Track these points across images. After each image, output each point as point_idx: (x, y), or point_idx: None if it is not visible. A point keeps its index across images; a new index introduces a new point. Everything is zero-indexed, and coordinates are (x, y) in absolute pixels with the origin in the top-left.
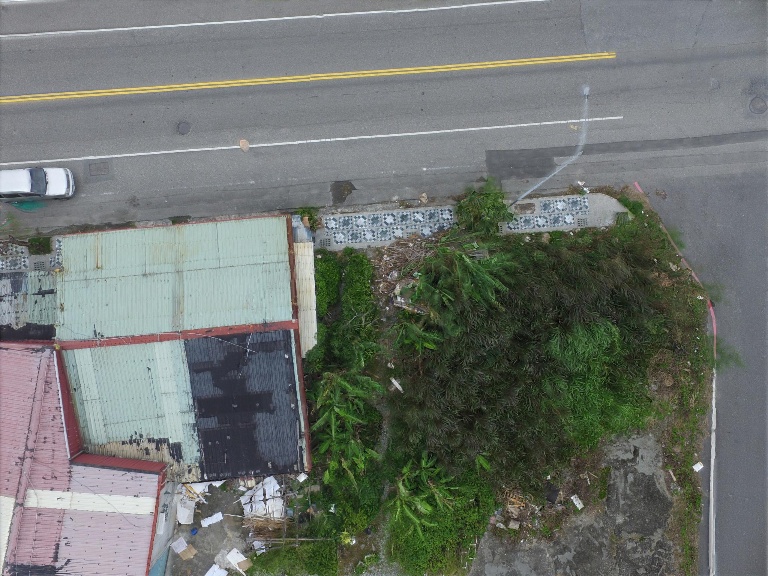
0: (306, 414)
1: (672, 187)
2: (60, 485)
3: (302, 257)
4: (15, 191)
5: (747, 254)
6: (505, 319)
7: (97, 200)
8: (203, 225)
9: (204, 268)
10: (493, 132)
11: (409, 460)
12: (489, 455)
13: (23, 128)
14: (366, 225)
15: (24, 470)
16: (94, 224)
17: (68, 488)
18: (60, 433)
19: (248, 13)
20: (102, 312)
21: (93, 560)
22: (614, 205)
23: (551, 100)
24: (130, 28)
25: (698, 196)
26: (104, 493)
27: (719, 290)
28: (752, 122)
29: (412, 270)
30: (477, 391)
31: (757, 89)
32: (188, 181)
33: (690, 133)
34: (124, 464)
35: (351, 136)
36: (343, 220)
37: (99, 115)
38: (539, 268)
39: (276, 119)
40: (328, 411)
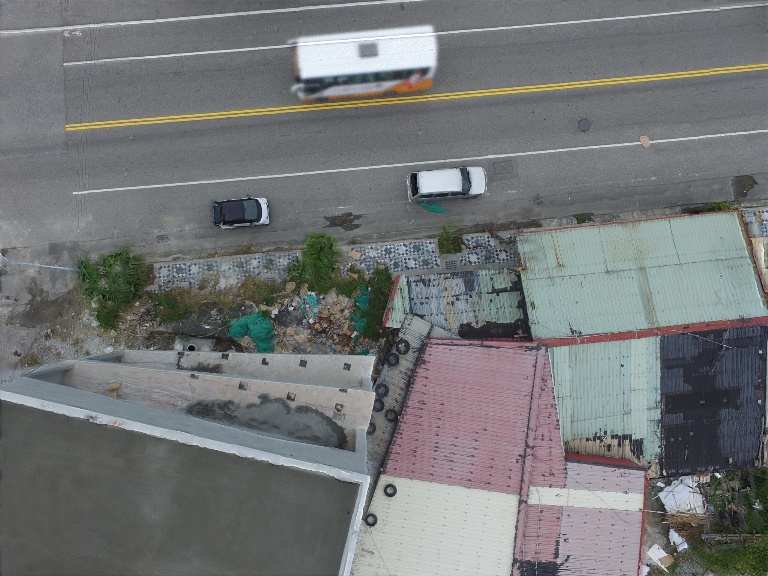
0: None
1: None
2: (558, 482)
3: None
4: (450, 190)
5: None
6: None
7: (501, 198)
8: (656, 221)
9: (667, 264)
10: None
11: None
12: None
13: (428, 128)
14: None
15: (527, 467)
16: (499, 222)
17: (564, 485)
18: (556, 430)
19: (643, 8)
20: (573, 310)
21: (590, 556)
22: None
23: None
24: (527, 26)
25: None
26: (597, 490)
27: None
28: None
29: None
30: None
31: None
32: (591, 178)
33: None
34: (604, 461)
35: (751, 130)
36: None
37: (501, 113)
38: None
39: (676, 114)
40: None
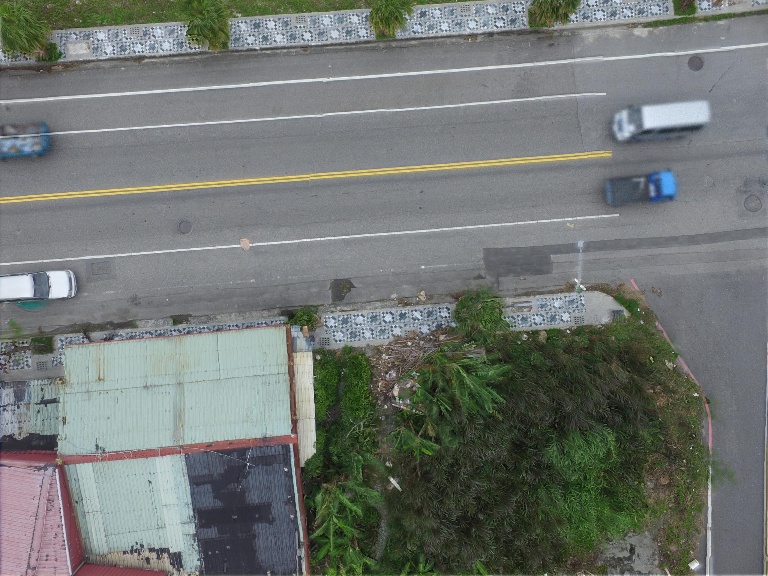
0: (305, 524)
1: (668, 284)
2: None
3: (301, 366)
4: (18, 297)
5: (742, 351)
6: (502, 429)
7: (99, 299)
8: (204, 335)
9: (205, 380)
10: (491, 230)
11: (407, 563)
12: (486, 561)
13: (26, 228)
14: (365, 323)
15: None
16: (96, 323)
17: None
18: (62, 550)
19: (249, 112)
20: (104, 425)
21: None
22: (610, 303)
23: (548, 198)
24: (132, 128)
25: (693, 293)
26: None
27: (714, 387)
28: (747, 220)
29: (410, 370)
30: (474, 496)
31: (752, 187)
32: (189, 280)
33: (685, 231)
34: None
35: (350, 234)
36: (342, 318)
37: (101, 215)
38: (536, 371)
39: (276, 218)
40: (327, 521)
